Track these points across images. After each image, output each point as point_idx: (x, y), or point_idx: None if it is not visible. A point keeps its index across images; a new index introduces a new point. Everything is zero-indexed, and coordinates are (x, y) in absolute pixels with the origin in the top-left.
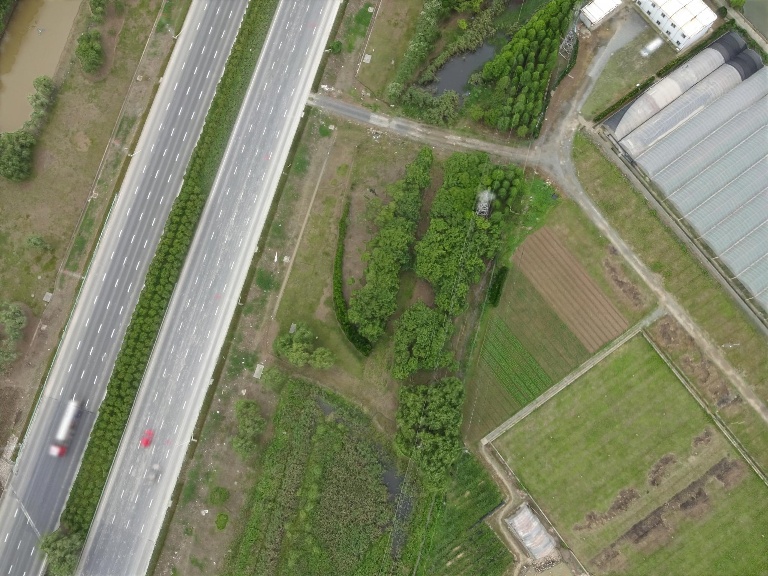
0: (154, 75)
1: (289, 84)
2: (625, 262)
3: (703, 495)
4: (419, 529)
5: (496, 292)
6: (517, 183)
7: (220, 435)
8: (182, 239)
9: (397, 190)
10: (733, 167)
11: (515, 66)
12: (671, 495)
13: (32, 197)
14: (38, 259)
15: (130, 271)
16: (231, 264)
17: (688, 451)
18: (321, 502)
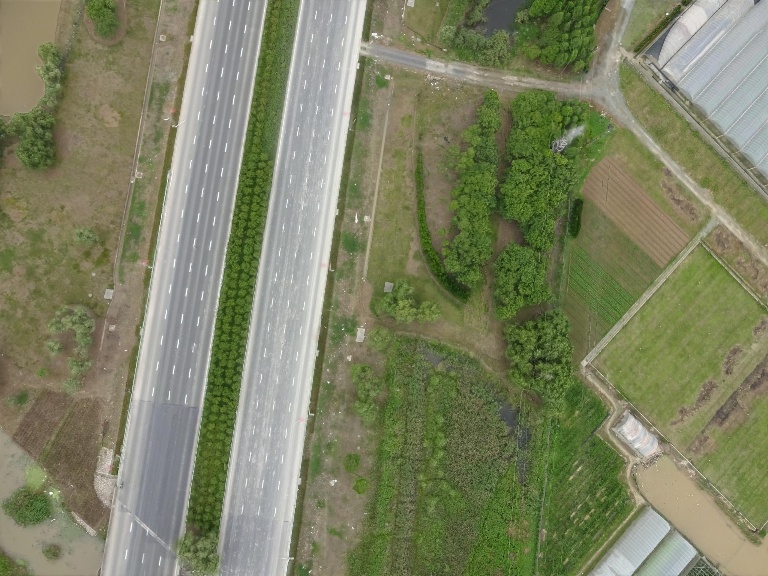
0: (181, 33)
1: (337, 34)
2: (679, 182)
3: (766, 375)
4: (541, 453)
5: (577, 224)
6: (585, 117)
7: (334, 405)
8: (260, 211)
9: (473, 135)
10: (759, 85)
11: (566, 1)
12: (742, 380)
13: (62, 185)
14: (87, 254)
15: (203, 253)
16: (313, 231)
17: (750, 340)
18: (448, 448)
